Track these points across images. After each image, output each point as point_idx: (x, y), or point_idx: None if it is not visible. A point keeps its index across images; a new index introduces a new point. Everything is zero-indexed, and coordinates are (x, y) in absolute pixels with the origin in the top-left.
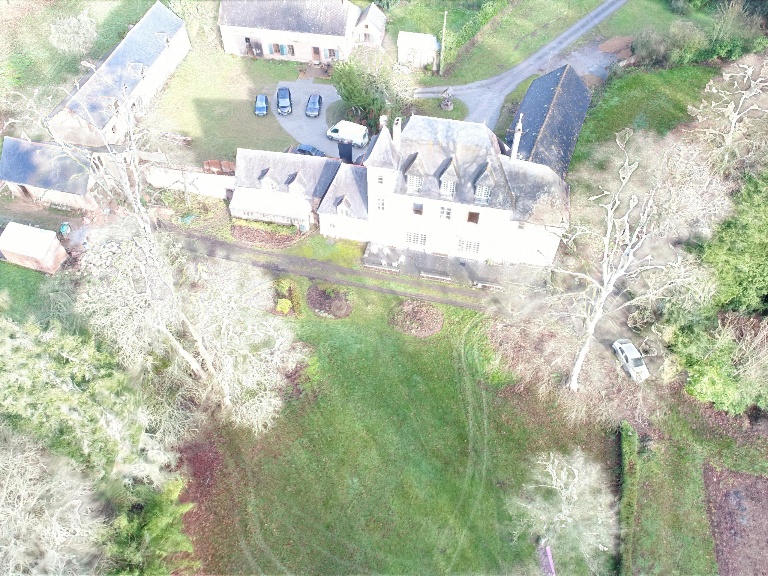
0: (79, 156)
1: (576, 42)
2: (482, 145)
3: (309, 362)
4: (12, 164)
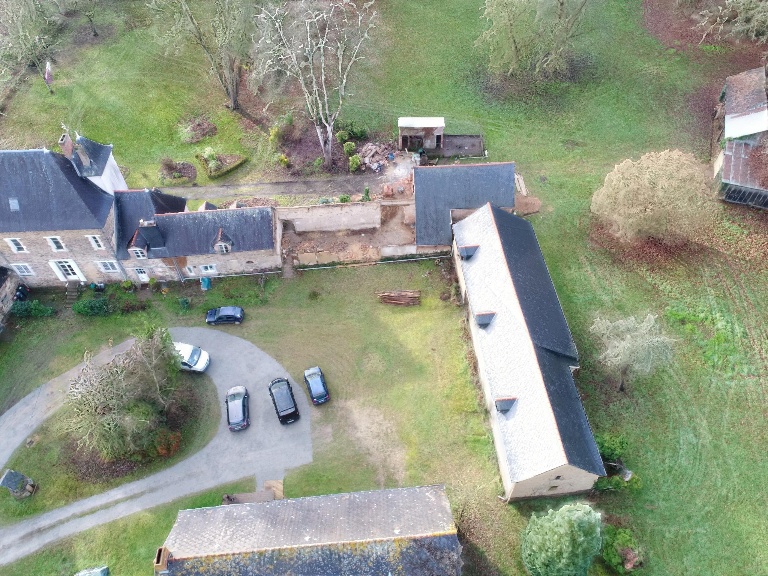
0: None
1: None
2: None
3: (186, 134)
4: None
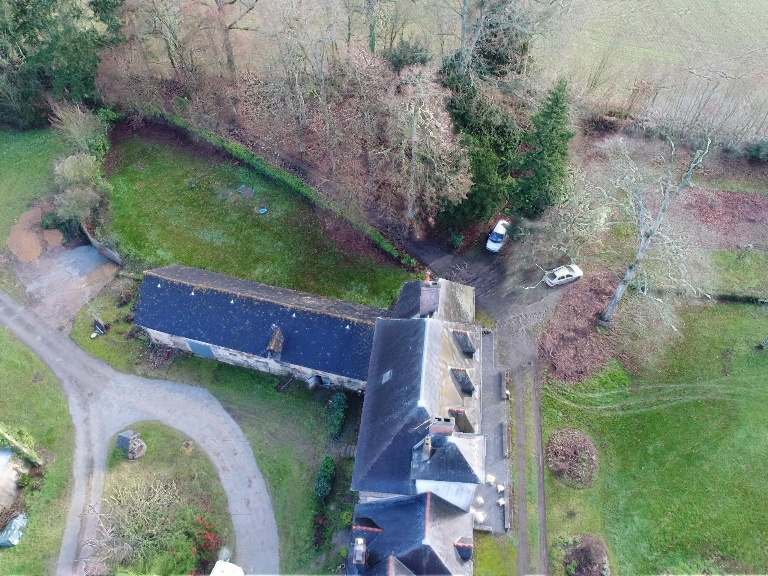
0: None
1: (3, 284)
2: (441, 330)
3: (685, 575)
4: None
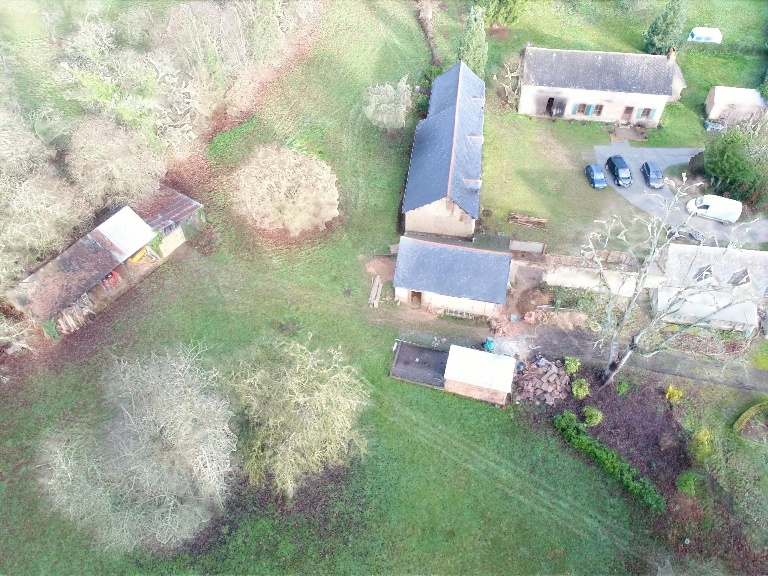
0: (496, 259)
1: None
2: None
3: None
4: (411, 268)
